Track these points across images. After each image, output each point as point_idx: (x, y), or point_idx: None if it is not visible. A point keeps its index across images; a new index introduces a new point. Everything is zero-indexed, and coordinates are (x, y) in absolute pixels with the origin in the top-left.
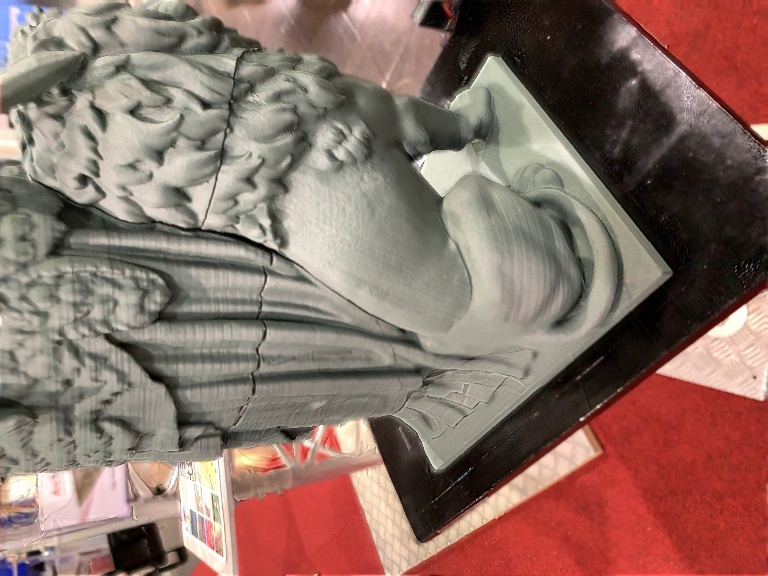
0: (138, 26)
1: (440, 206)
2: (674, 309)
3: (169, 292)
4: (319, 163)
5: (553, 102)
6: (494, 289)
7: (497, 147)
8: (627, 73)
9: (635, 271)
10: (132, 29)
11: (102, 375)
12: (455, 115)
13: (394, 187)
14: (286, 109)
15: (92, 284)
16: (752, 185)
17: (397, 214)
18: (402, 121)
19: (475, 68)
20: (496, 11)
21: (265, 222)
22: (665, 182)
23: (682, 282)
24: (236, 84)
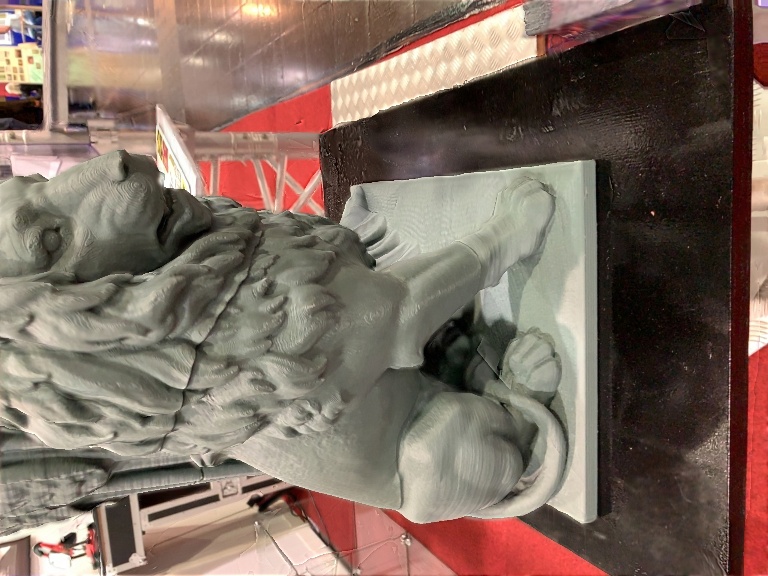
0: (62, 336)
1: (405, 426)
2: (580, 533)
3: (107, 474)
4: (275, 434)
5: (610, 279)
6: (419, 520)
7: (527, 276)
8: (689, 353)
9: (566, 501)
10: (54, 338)
11: (43, 521)
12: (488, 261)
13: (353, 448)
14: (244, 417)
15: (27, 487)
16: (695, 552)
17: (347, 469)
18: (397, 350)
19: (566, 131)
20: (627, 98)
21: (207, 463)
22: (642, 465)
23: (598, 529)
24: (185, 403)
